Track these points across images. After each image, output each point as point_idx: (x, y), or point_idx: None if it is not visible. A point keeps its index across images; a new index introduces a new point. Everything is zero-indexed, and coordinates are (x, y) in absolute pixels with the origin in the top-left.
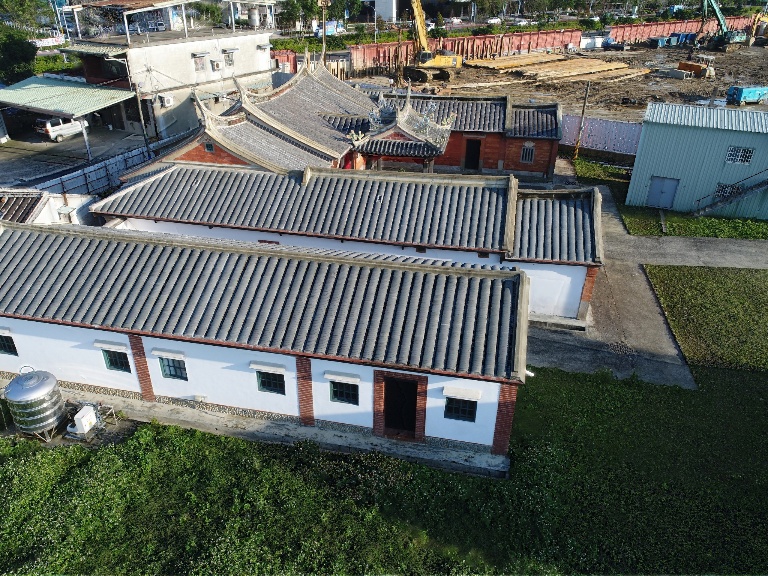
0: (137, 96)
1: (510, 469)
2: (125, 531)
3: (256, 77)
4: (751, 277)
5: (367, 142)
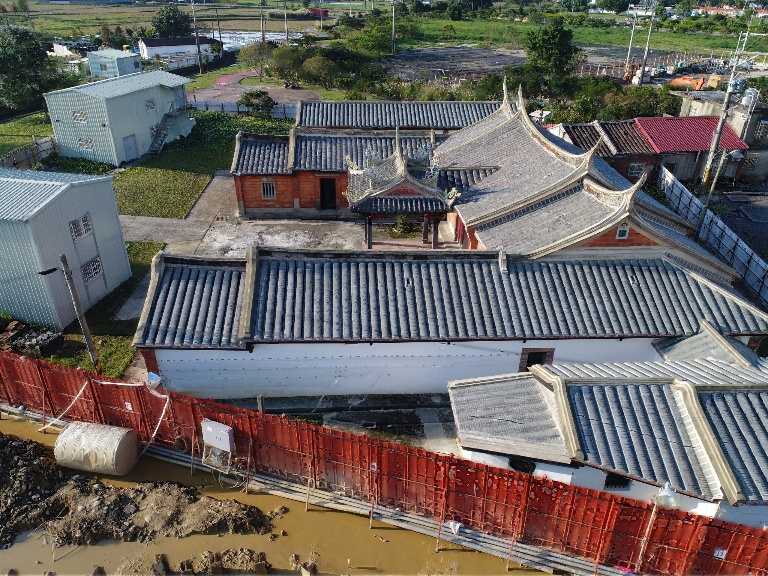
0: None
1: None
2: None
3: None
4: None
5: None
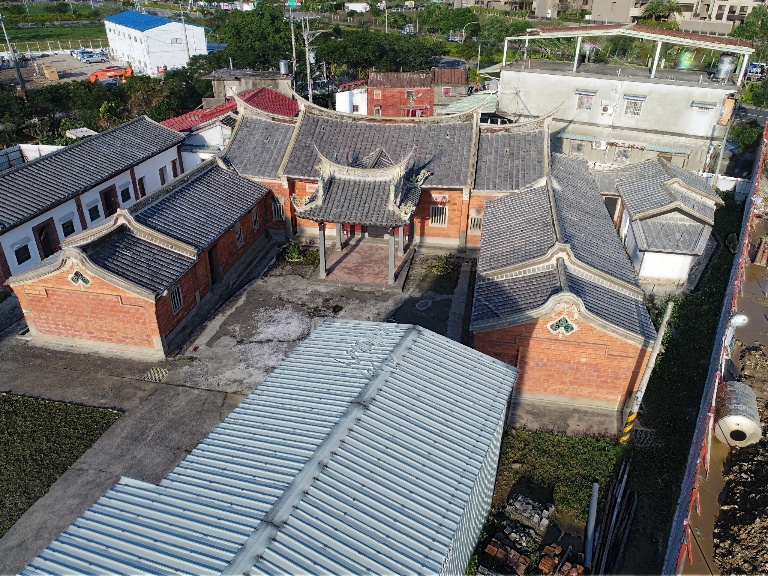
0: None
1: None
2: None
3: (676, 139)
4: (1, 498)
5: None
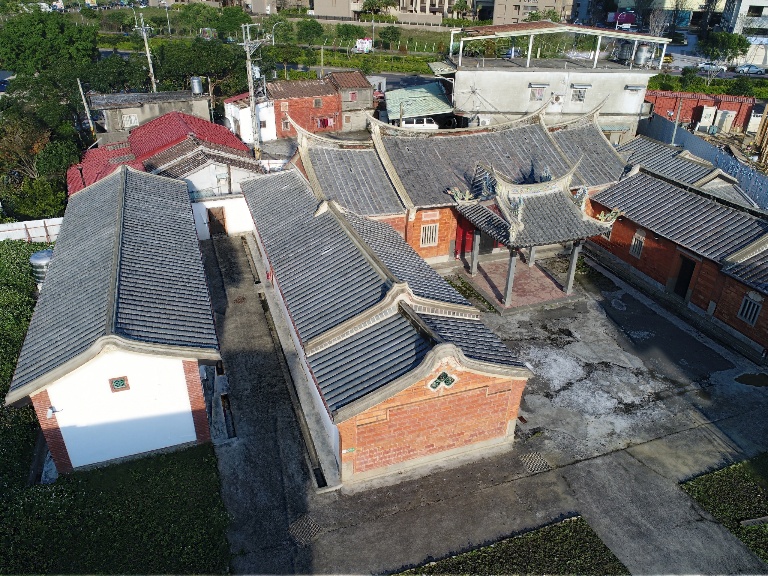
0: (401, 111)
1: None
2: None
3: (613, 119)
4: None
5: (475, 205)
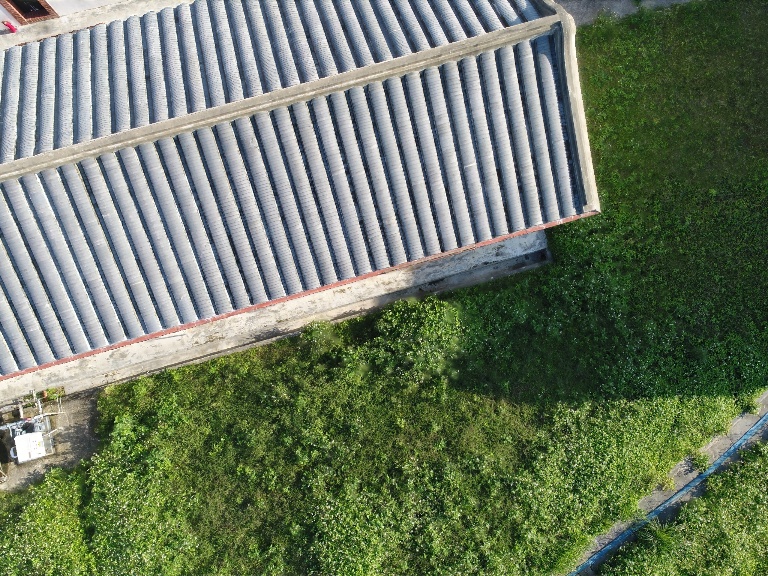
0: None
1: (550, 246)
2: (212, 545)
3: None
4: None
5: None
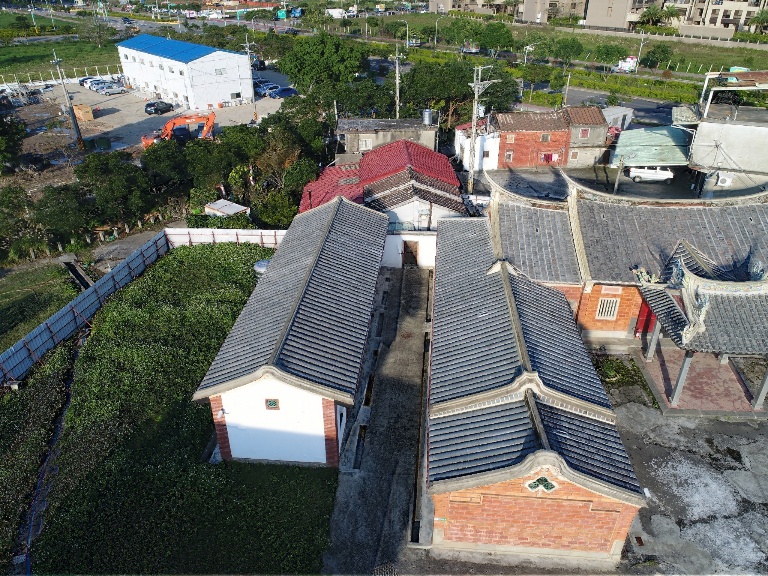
0: (620, 164)
1: None
2: None
3: None
4: None
5: (660, 290)
